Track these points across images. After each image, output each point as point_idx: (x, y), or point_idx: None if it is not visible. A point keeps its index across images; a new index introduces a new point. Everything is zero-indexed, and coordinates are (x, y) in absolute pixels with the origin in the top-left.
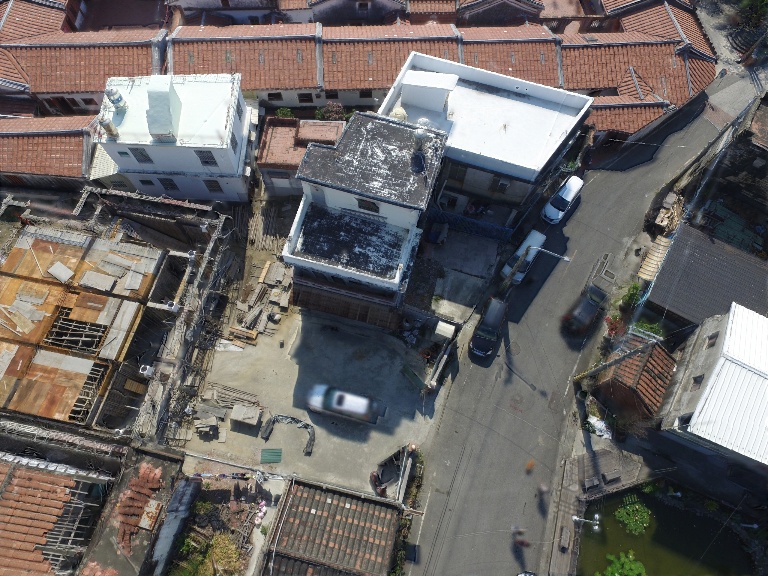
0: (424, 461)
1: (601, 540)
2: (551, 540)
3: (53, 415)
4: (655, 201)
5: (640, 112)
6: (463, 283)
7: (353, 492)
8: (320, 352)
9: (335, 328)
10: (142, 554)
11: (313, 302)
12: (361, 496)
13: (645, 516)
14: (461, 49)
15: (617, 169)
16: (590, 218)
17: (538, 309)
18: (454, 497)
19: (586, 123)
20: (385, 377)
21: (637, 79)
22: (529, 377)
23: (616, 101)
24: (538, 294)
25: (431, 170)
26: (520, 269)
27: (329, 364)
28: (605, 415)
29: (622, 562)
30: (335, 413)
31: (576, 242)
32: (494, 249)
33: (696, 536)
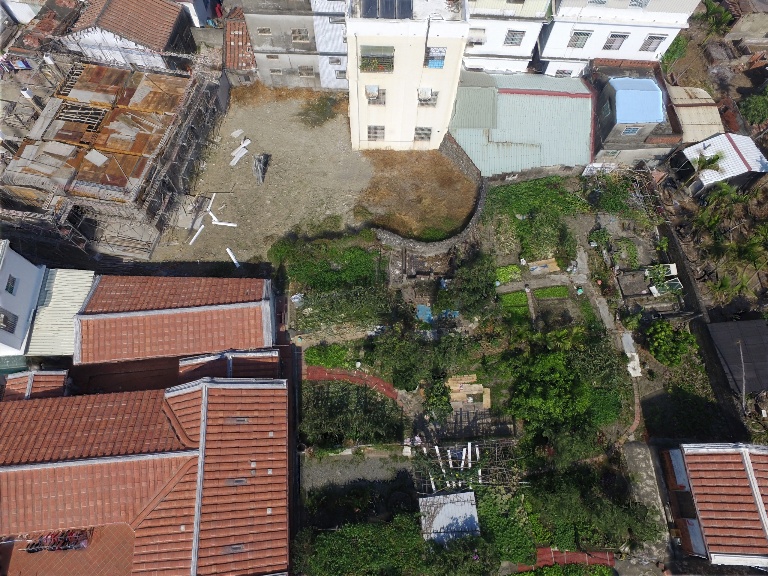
0: None
1: None
2: None
3: (97, 67)
4: None
5: None
6: None
7: None
8: None
9: None
10: (41, 11)
11: None
12: None
13: None
14: None
15: None
16: None
17: None
18: None
19: None
20: None
21: None
22: None
23: None
24: None
25: None
26: None
27: None
28: None
29: None
30: None
31: None
32: None
33: None
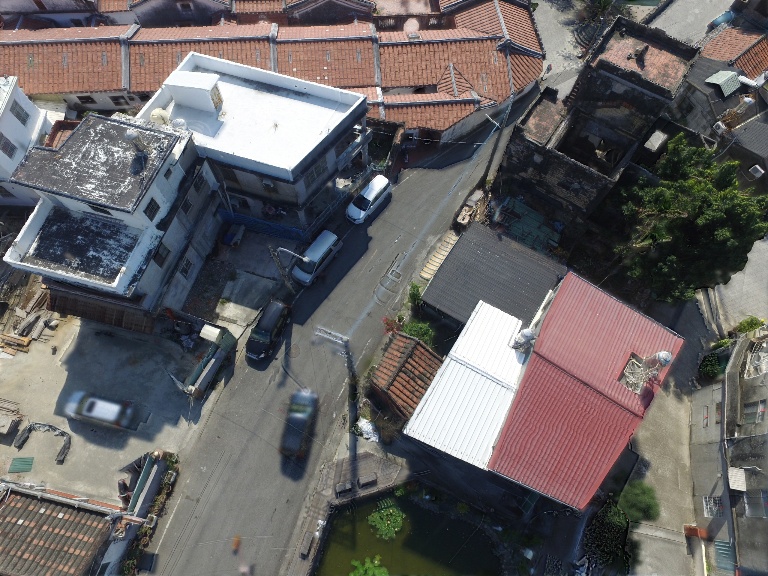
0: (180, 468)
1: (349, 545)
2: (295, 546)
3: None
4: (465, 199)
5: (451, 109)
6: (253, 285)
7: (68, 501)
8: (93, 358)
9: (108, 333)
10: None
11: (70, 307)
12: (75, 505)
13: (398, 520)
14: (273, 49)
15: (435, 167)
16: (397, 217)
17: (326, 310)
18: (202, 504)
19: (394, 121)
20: (155, 382)
21: (456, 76)
22: (304, 380)
23: (429, 98)
24: (329, 295)
25: (150, 171)
26: (308, 270)
27: (100, 370)
28: (376, 417)
29: (365, 568)
30: (96, 420)
31: (378, 242)
32: (291, 250)
33: (447, 540)
